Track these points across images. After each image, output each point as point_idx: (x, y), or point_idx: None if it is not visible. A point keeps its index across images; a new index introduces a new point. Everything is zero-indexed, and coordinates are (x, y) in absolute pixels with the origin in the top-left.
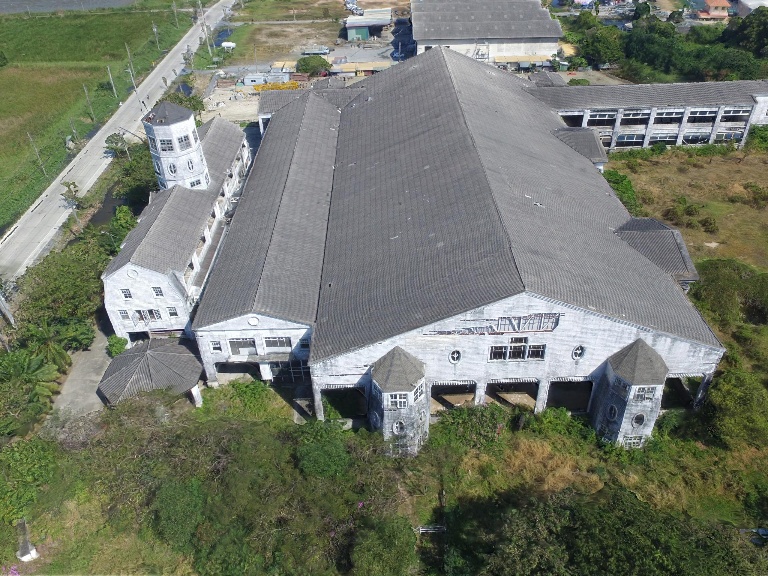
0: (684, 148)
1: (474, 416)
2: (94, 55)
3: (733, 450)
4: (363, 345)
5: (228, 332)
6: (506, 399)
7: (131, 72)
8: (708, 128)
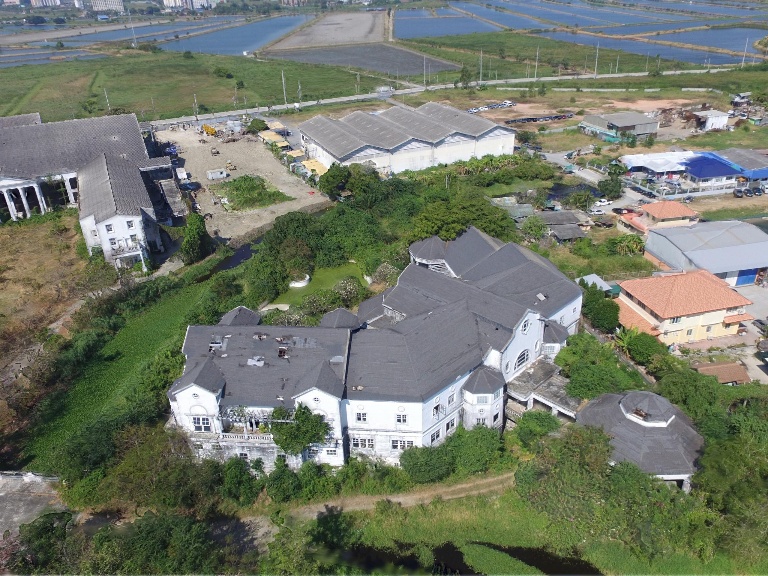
0: None
1: None
2: None
3: None
4: None
5: None
6: None
7: None
8: None
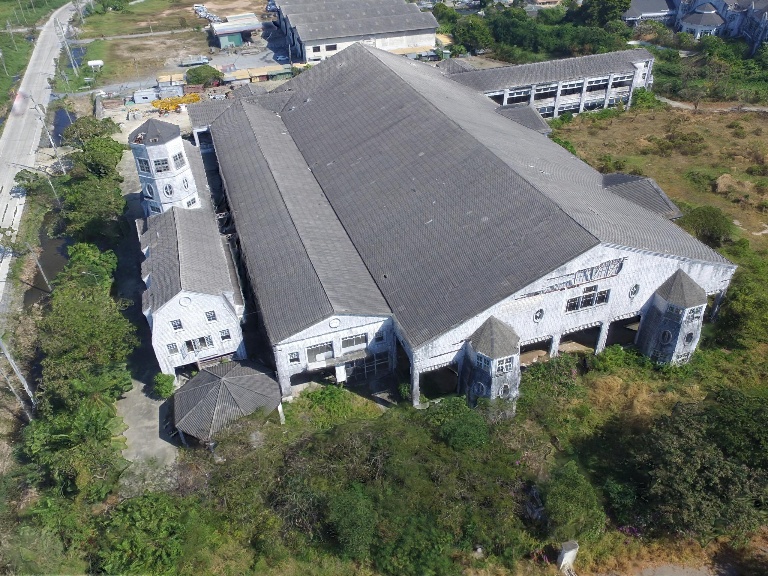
0: None
1: (552, 368)
2: None
3: (750, 348)
4: (463, 321)
5: (307, 340)
6: (559, 350)
7: None
8: (602, 95)
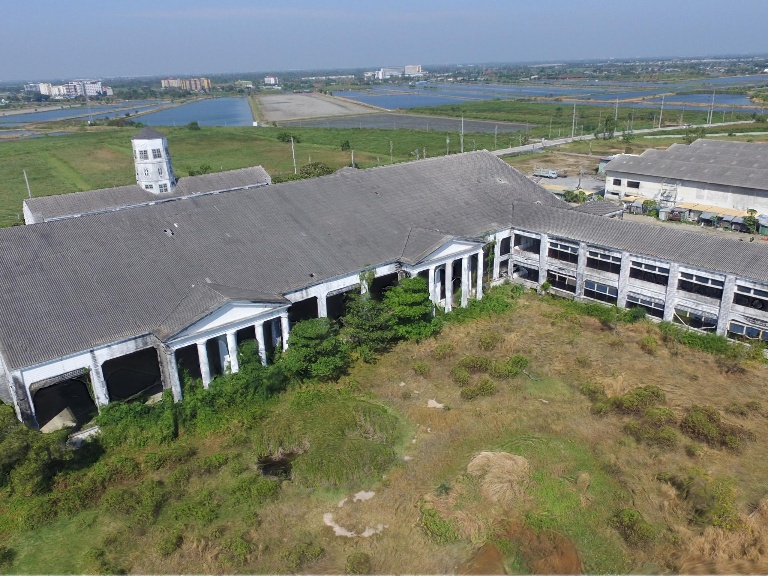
0: (670, 326)
1: None
2: None
3: None
4: None
5: None
6: None
7: None
8: (713, 307)
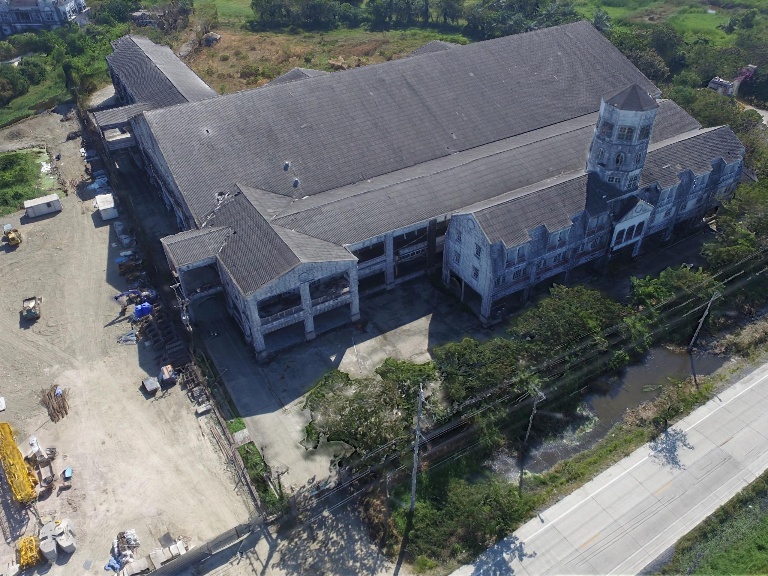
0: None
1: None
2: None
3: None
4: None
5: None
6: None
7: None
8: None
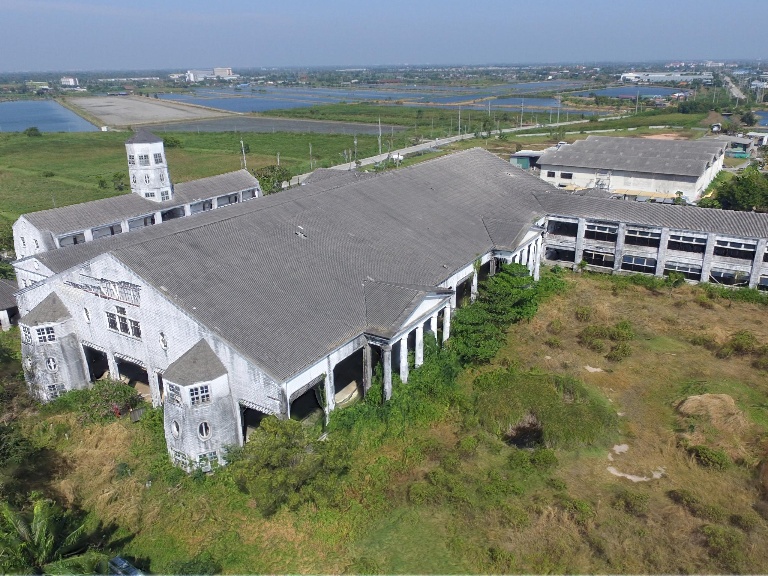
0: (709, 286)
1: None
2: (306, 155)
3: (270, 520)
4: None
5: (29, 273)
6: None
7: (312, 166)
8: (745, 266)
